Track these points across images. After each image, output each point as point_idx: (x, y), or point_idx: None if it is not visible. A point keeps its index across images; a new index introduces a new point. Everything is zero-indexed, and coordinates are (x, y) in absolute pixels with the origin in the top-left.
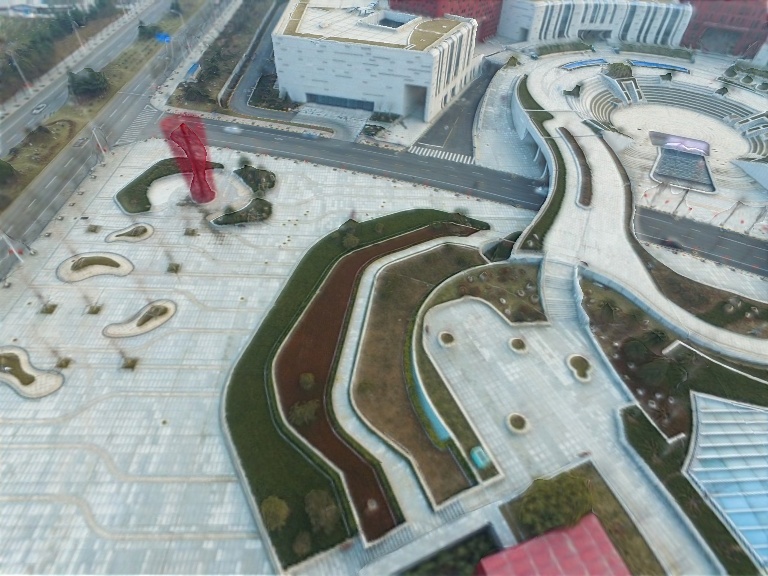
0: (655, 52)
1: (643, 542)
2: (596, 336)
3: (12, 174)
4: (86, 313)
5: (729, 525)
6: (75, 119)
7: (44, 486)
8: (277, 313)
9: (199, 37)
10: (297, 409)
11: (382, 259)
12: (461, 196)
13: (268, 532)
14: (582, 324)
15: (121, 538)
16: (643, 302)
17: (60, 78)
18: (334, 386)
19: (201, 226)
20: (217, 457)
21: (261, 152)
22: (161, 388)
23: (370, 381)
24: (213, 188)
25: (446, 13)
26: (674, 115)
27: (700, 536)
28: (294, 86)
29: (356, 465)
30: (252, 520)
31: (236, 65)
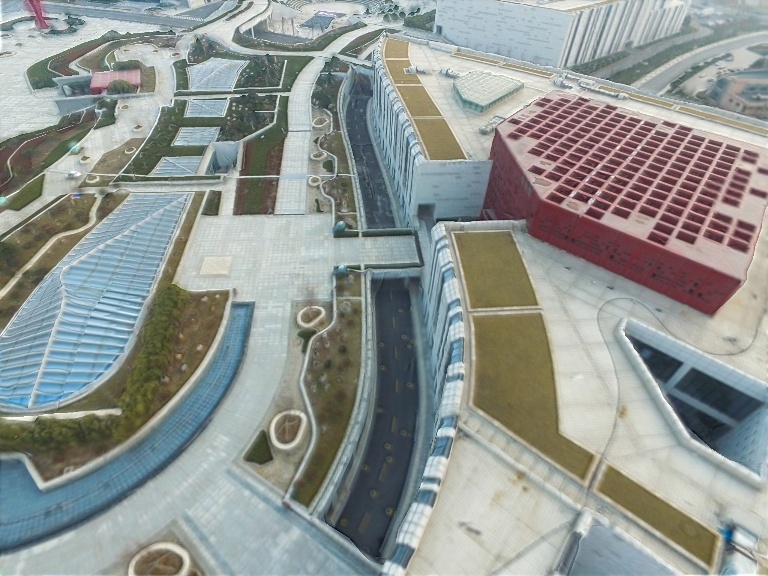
0: None
1: (154, 75)
2: (190, 49)
3: None
4: None
5: None
6: None
7: None
8: (61, 53)
9: None
10: None
11: None
12: None
13: (31, 85)
14: None
15: None
16: (220, 42)
17: None
18: None
19: (38, 35)
20: None
21: None
22: (3, 68)
23: None
24: (49, 25)
25: None
26: (344, 6)
27: None
28: None
29: None
30: (28, 87)
31: None
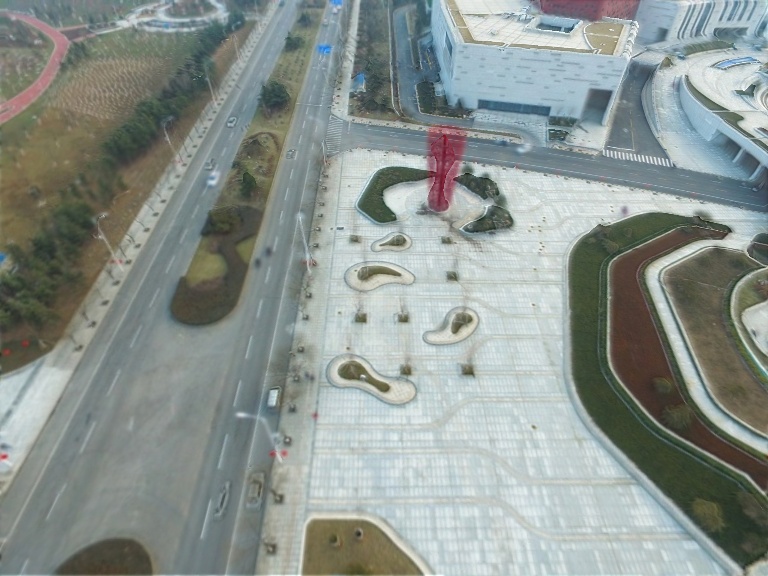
0: None
1: None
2: None
3: (255, 187)
4: (397, 321)
5: None
6: (273, 131)
7: (459, 489)
8: (580, 319)
9: None
10: (673, 413)
11: (654, 264)
12: (683, 199)
13: (706, 533)
14: None
15: (562, 539)
16: None
17: (233, 91)
18: (690, 390)
19: (453, 234)
20: (604, 460)
21: (465, 159)
22: (510, 393)
23: (726, 385)
24: None
25: (604, 16)
26: None
27: None
28: (468, 93)
29: (758, 468)
30: (675, 521)
31: (390, 73)
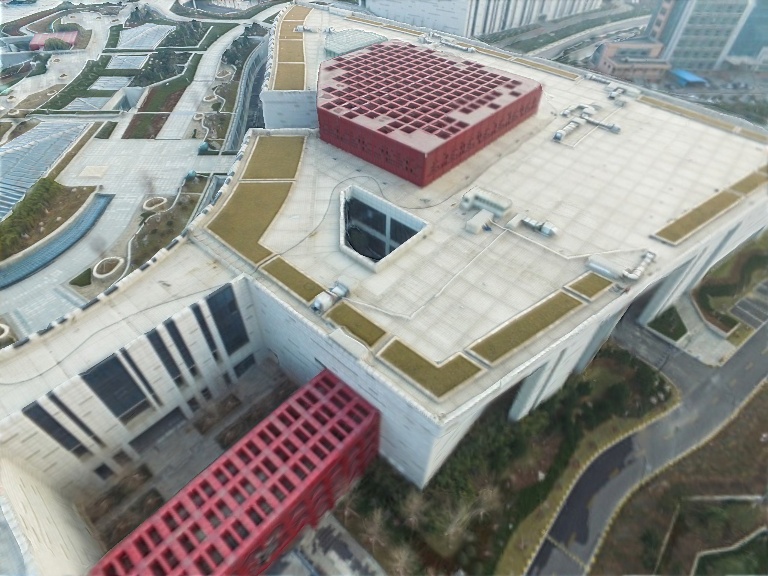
0: None
1: (90, 36)
2: (130, 16)
3: None
4: None
5: None
6: None
7: None
8: None
9: None
10: (5, 27)
11: None
12: None
13: None
14: None
15: None
16: (158, 11)
17: None
18: None
19: (0, 5)
20: None
21: None
22: None
23: None
24: None
25: None
26: None
27: None
28: None
29: None
30: None
31: None
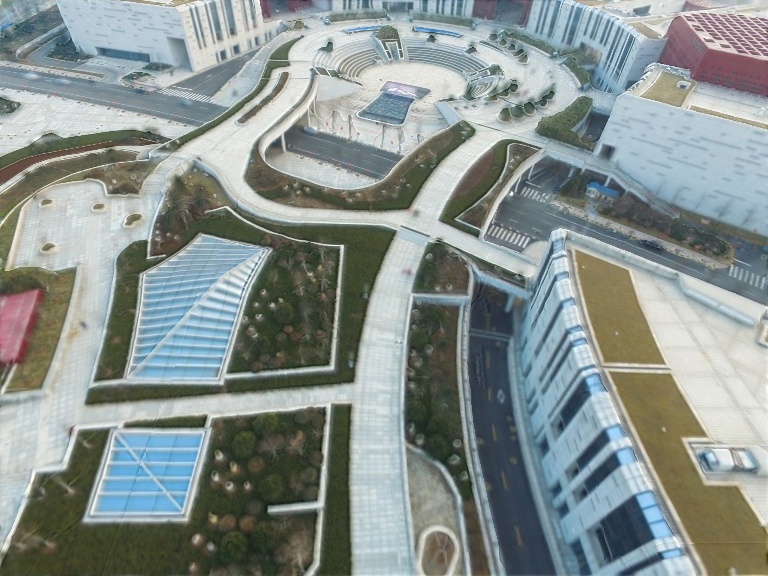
0: (444, 21)
1: (67, 306)
2: (163, 202)
3: None
4: None
5: (140, 300)
6: None
7: None
8: None
9: (37, 4)
10: None
11: (53, 158)
12: (172, 122)
13: None
14: (162, 196)
15: None
16: (221, 183)
17: None
18: None
19: None
20: None
21: (24, 89)
22: None
23: None
24: None
25: None
26: (424, 70)
27: (111, 304)
28: (84, 40)
29: None
30: None
31: (56, 26)
